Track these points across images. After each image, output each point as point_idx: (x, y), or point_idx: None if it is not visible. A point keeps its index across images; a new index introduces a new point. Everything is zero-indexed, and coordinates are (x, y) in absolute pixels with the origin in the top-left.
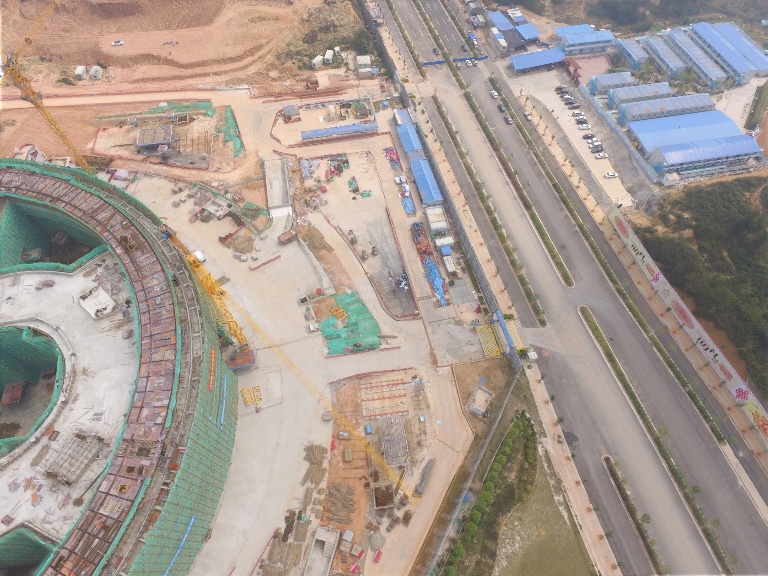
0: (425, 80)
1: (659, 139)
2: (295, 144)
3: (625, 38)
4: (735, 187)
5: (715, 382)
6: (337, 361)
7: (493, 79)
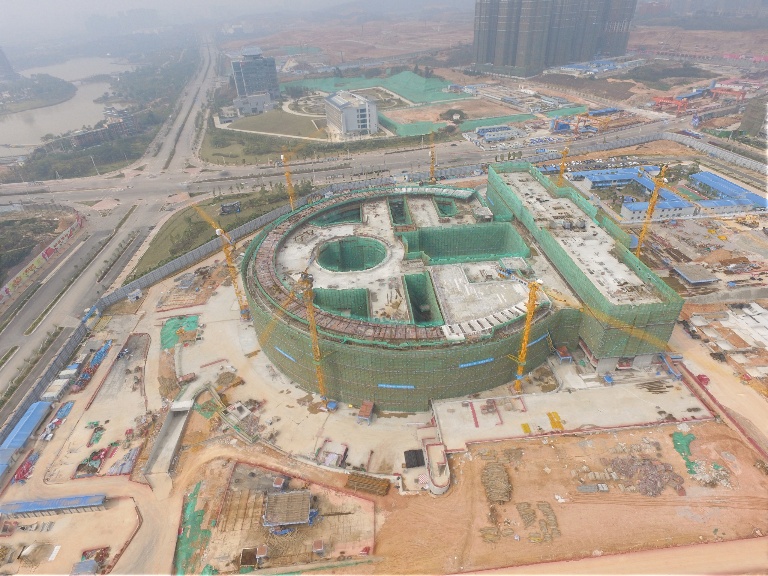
0: None
1: None
2: (120, 498)
3: None
4: None
5: (9, 301)
6: None
7: None
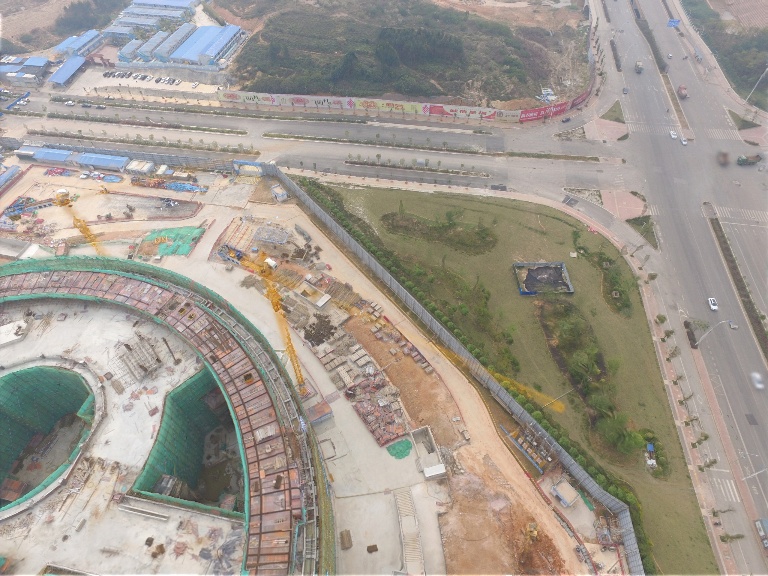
0: (4, 131)
1: (194, 52)
2: None
3: (105, 28)
4: (251, 44)
5: (339, 111)
6: (196, 252)
7: (55, 98)
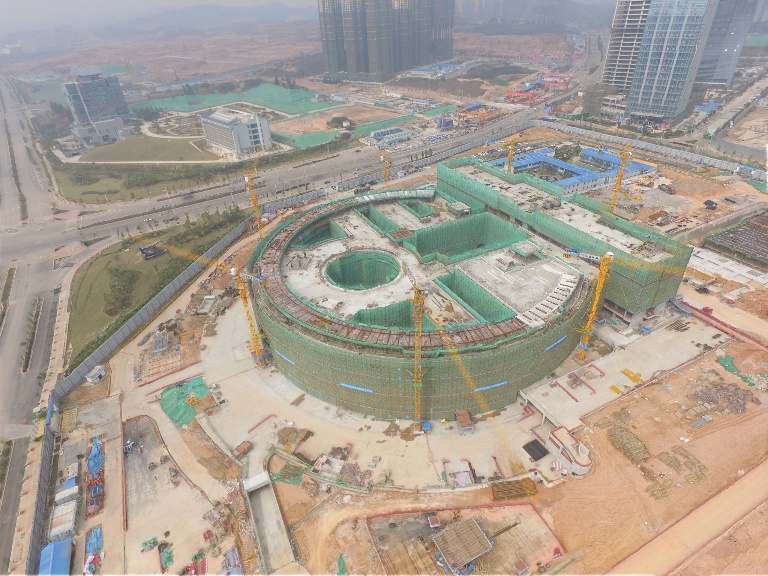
0: None
1: None
2: None
3: None
4: None
5: None
6: None
7: None
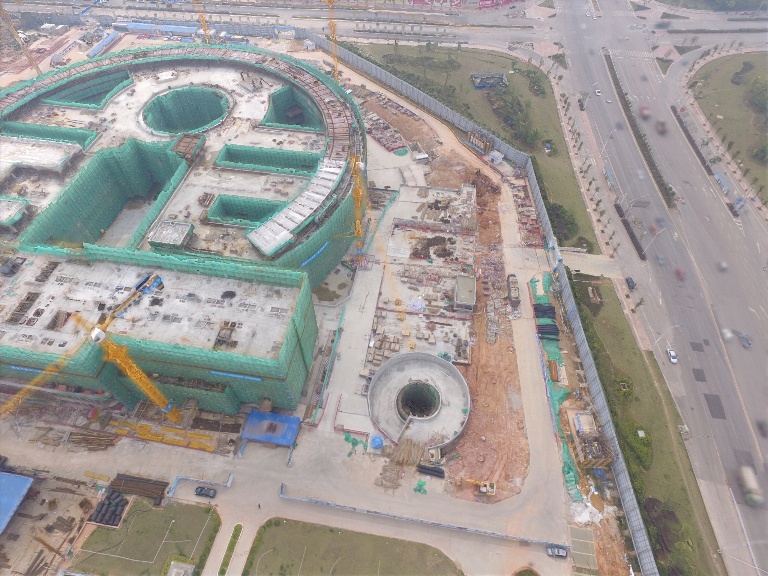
0: None
1: None
2: None
3: None
4: None
5: (346, 3)
6: None
7: None
